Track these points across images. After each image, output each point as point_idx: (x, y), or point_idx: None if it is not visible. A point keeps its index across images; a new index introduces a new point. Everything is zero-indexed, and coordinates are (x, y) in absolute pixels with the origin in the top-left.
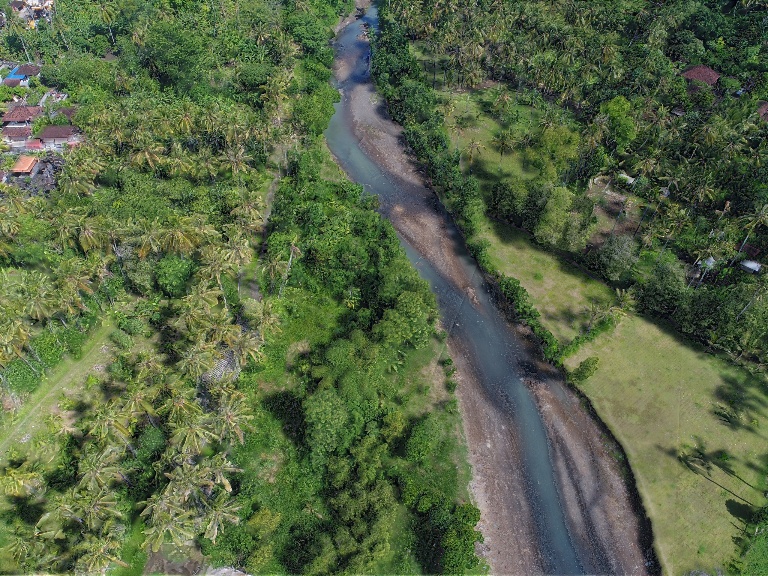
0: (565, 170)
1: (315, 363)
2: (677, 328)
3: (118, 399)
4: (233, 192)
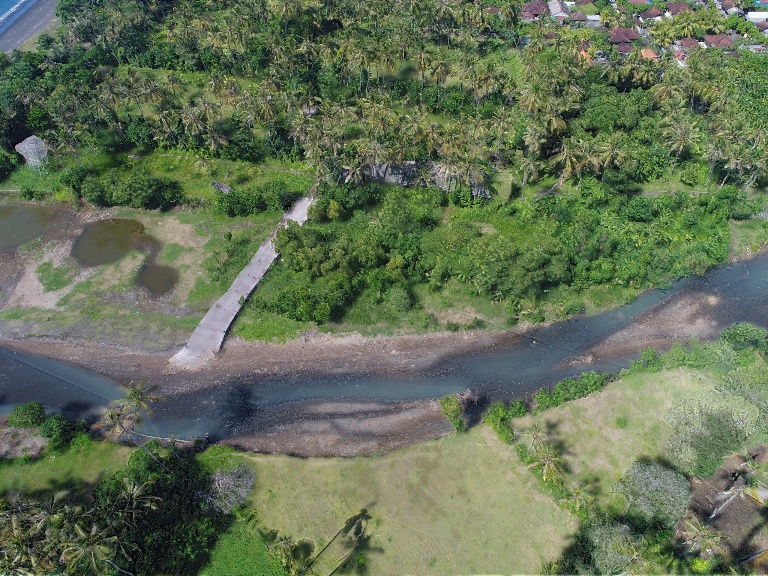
0: None
1: None
2: None
3: None
4: (647, 151)
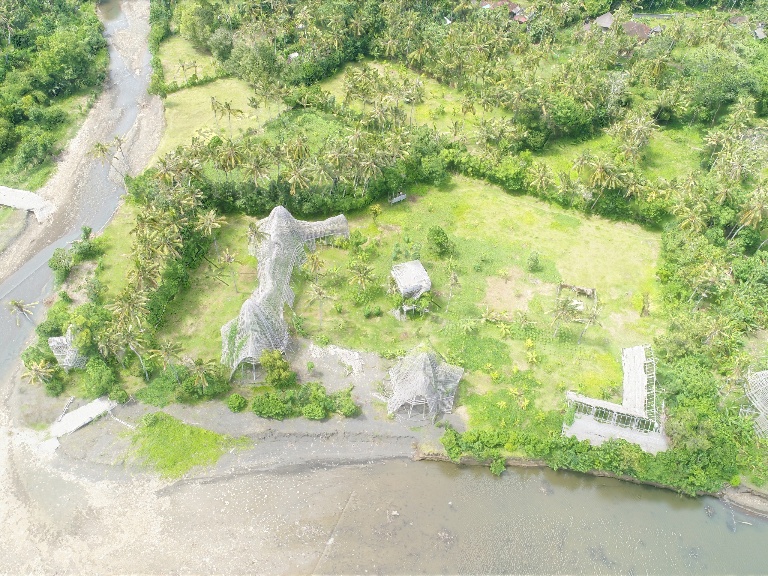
0: (223, 5)
1: (5, 85)
2: (249, 84)
3: None
4: None
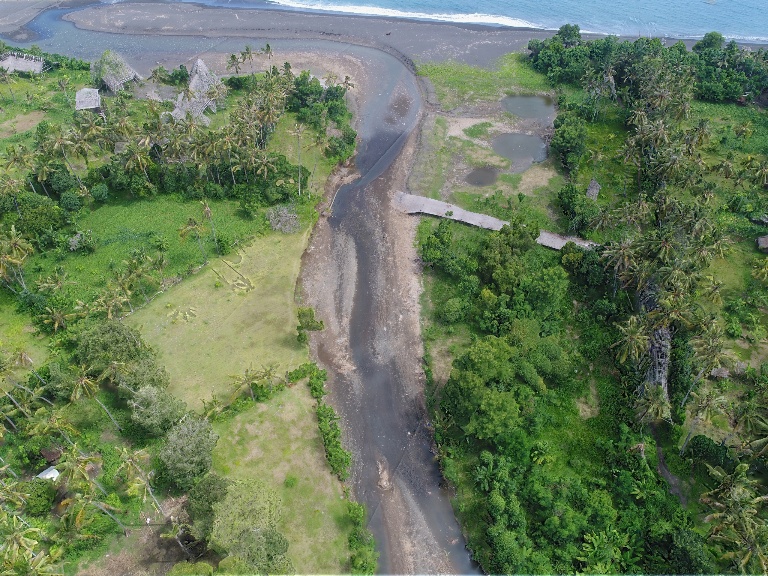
0: None
1: None
2: None
3: (714, 247)
4: None
